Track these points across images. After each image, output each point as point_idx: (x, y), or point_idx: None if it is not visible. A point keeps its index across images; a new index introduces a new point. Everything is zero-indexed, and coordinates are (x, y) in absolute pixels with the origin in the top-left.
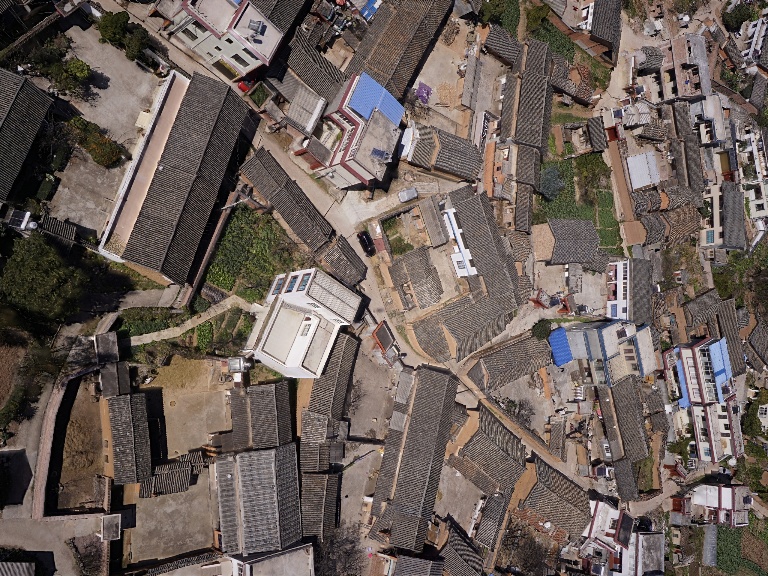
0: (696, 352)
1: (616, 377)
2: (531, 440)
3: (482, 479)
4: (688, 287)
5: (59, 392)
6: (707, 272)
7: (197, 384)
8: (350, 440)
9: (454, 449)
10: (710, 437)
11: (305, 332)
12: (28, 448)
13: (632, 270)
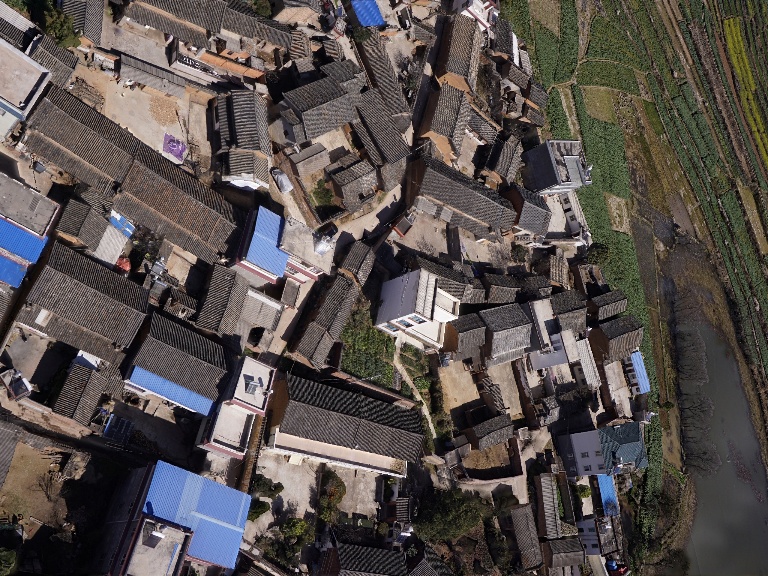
0: None
1: None
2: None
3: None
4: None
5: None
6: None
7: (443, 384)
8: (453, 255)
9: None
10: None
11: None
12: (490, 490)
13: None
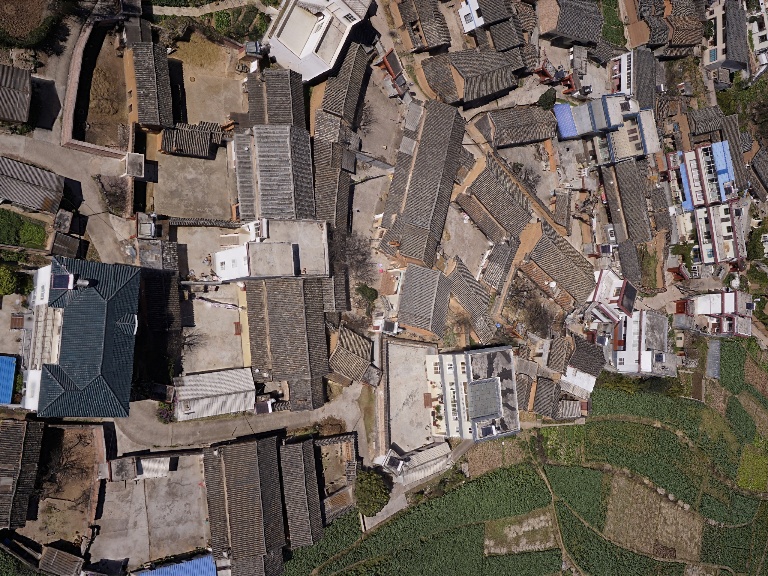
0: (699, 153)
1: (620, 155)
2: (537, 208)
3: (489, 224)
4: (691, 101)
5: (86, 30)
6: (710, 91)
7: (215, 68)
8: (361, 158)
9: (462, 189)
10: (713, 237)
11: (318, 29)
12: (57, 81)
13: (636, 60)
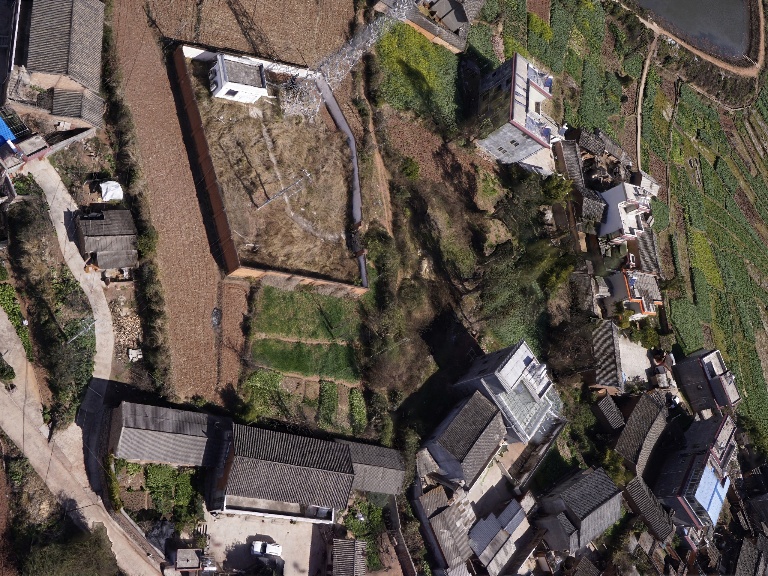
0: None
1: None
2: None
3: None
4: None
5: None
6: None
7: None
8: None
9: None
10: None
11: None
12: None
13: None
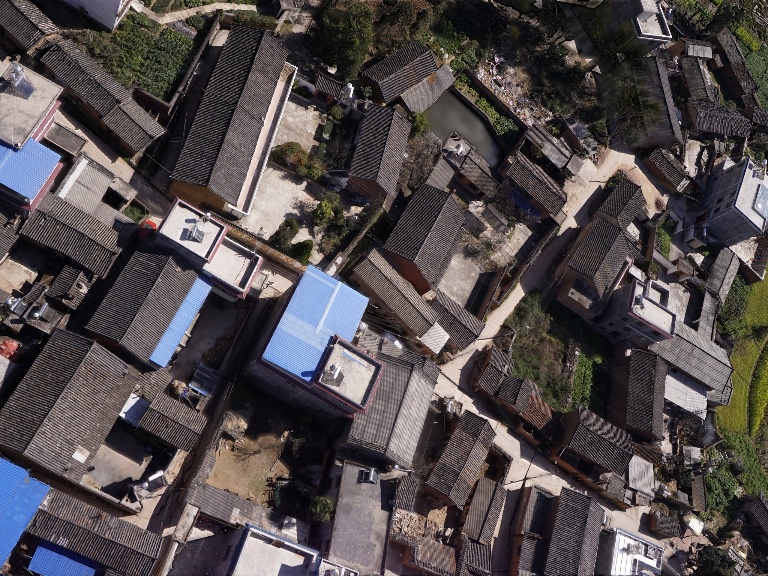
0: None
1: None
2: None
3: None
4: None
5: None
6: None
7: None
8: None
9: None
10: None
11: None
12: None
13: None
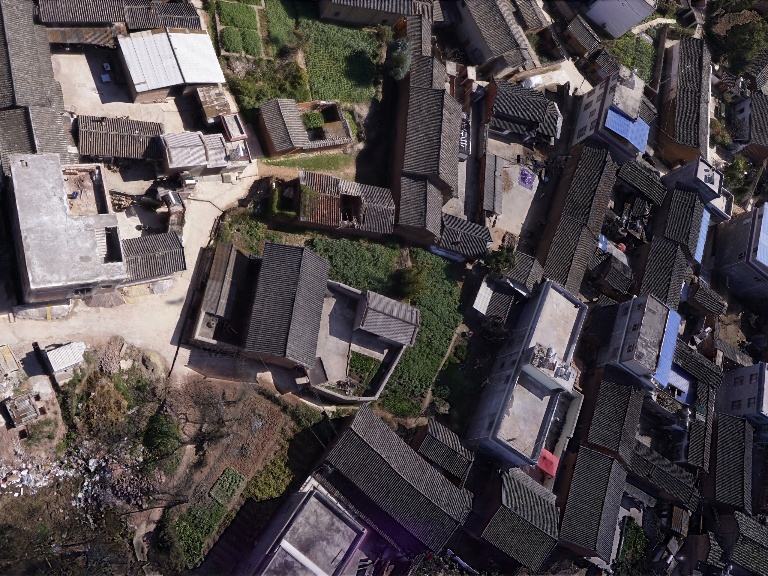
0: None
1: None
2: None
3: None
4: None
5: None
6: None
7: None
8: None
9: None
10: None
11: None
12: None
13: None
